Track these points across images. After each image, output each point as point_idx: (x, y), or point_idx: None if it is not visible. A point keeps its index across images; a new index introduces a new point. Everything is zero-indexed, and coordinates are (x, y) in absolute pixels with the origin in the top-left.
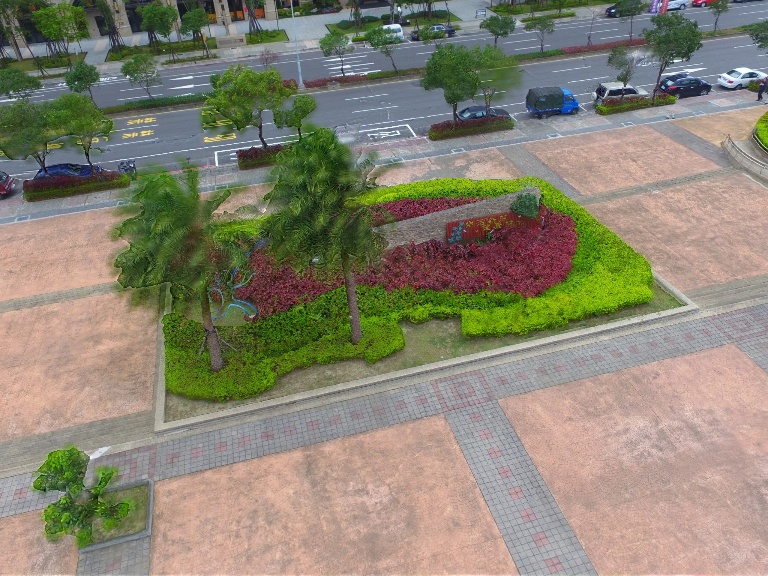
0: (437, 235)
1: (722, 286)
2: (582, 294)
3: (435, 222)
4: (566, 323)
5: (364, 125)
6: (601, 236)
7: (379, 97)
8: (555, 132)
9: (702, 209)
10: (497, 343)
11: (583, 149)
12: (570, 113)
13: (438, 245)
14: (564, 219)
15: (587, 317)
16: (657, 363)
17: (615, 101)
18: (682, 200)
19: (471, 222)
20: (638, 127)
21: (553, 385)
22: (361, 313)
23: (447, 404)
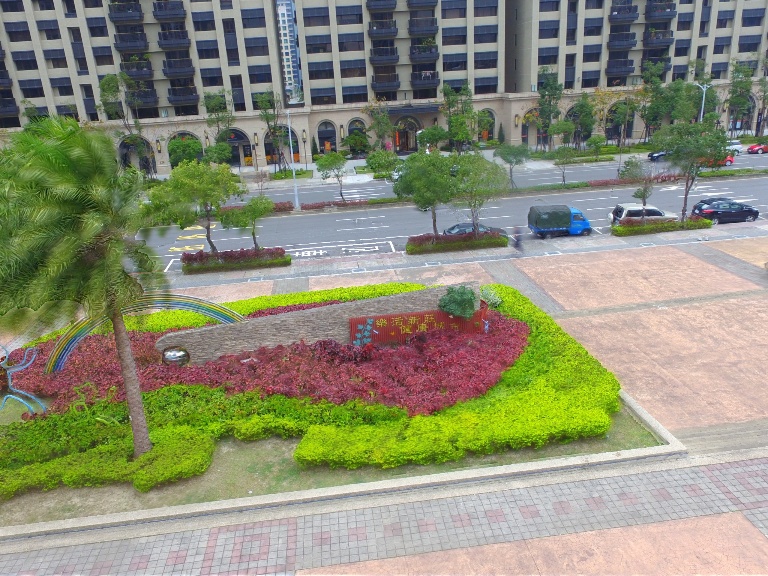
0: (338, 335)
1: (740, 425)
2: (498, 415)
3: (333, 316)
4: (462, 456)
5: (343, 241)
6: (560, 347)
7: (373, 219)
8: (555, 250)
9: (725, 329)
10: (345, 478)
11: (584, 266)
12: (580, 234)
13: (328, 344)
14: (515, 325)
15: (498, 450)
16: (594, 533)
17: (633, 221)
18: (698, 318)
19: (383, 320)
20: (659, 247)
21: (401, 554)
22: (171, 420)
23: (212, 569)
